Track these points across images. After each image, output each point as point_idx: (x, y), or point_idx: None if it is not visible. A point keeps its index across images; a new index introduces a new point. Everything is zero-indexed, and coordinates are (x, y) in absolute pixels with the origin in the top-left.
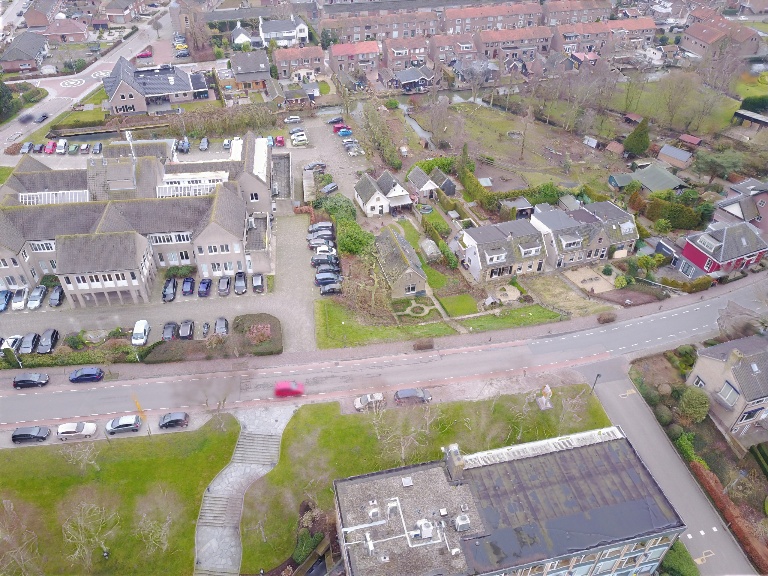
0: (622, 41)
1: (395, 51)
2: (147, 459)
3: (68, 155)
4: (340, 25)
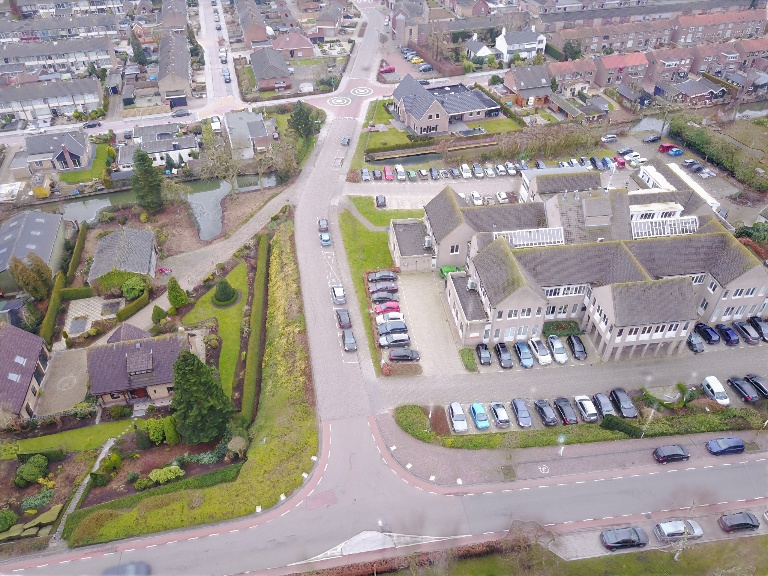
0: None
1: (666, 63)
2: None
3: (409, 181)
4: (582, 35)
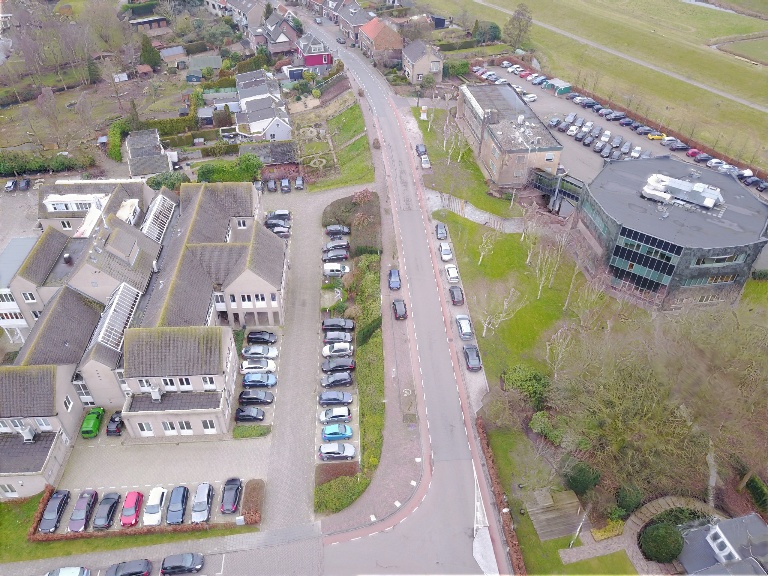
0: (24, 5)
1: None
2: (470, 243)
3: None
4: None
